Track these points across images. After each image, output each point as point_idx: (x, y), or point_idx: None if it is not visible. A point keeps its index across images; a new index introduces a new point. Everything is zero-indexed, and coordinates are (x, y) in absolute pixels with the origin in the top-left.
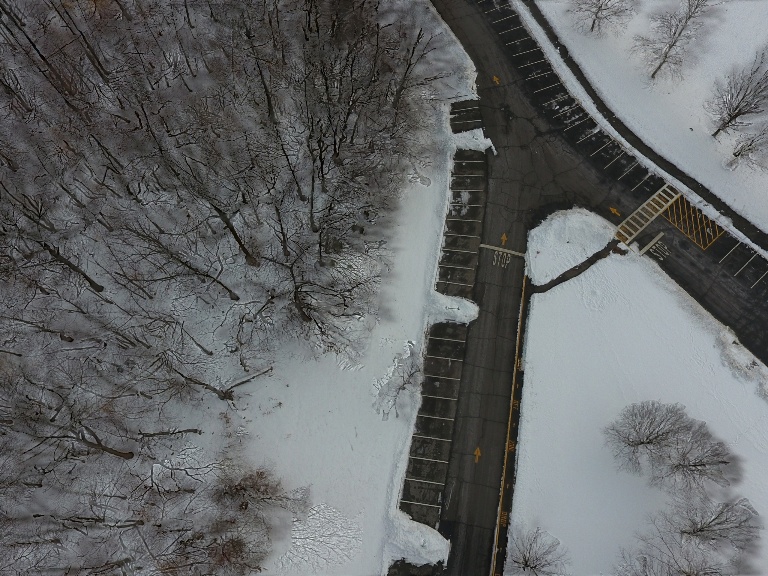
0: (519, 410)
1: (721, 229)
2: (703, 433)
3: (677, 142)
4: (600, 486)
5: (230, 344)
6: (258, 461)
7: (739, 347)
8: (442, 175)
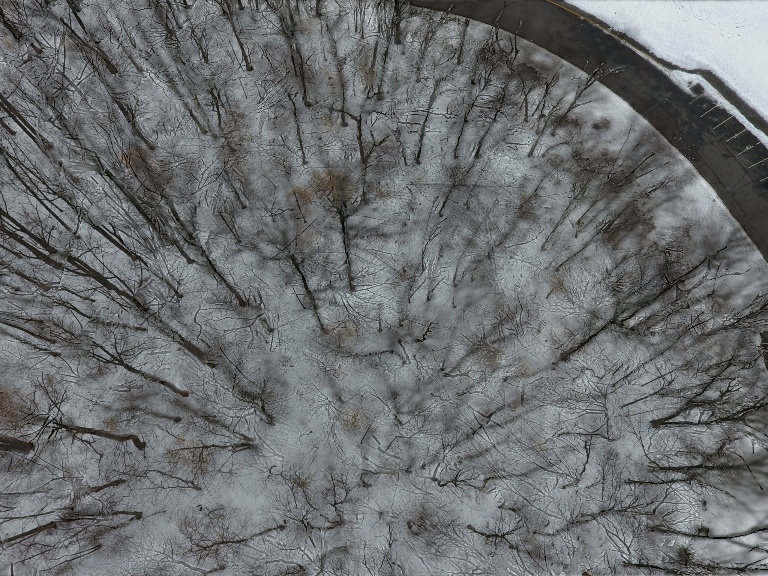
0: None
1: None
2: None
3: None
4: None
5: None
6: None
7: None
8: None
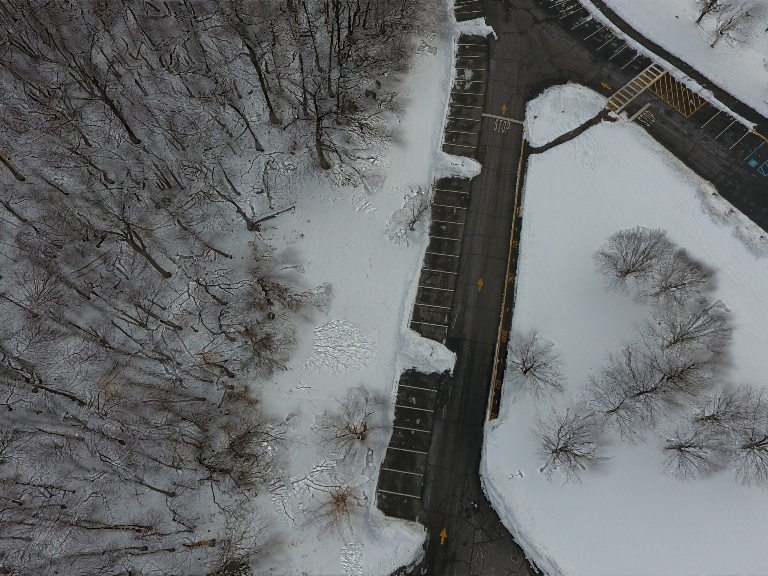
0: (518, 249)
1: (703, 100)
2: (684, 259)
3: (664, 27)
4: (591, 306)
5: (256, 186)
6: (283, 280)
7: (718, 198)
8: (447, 56)
